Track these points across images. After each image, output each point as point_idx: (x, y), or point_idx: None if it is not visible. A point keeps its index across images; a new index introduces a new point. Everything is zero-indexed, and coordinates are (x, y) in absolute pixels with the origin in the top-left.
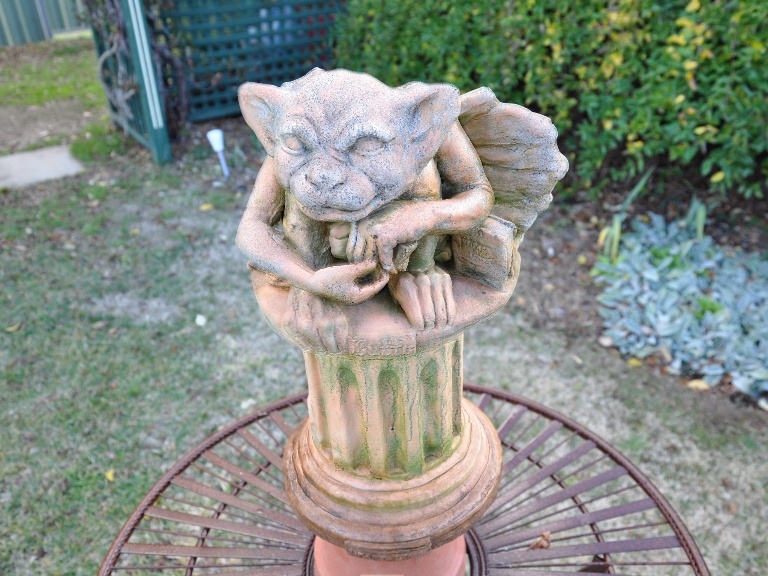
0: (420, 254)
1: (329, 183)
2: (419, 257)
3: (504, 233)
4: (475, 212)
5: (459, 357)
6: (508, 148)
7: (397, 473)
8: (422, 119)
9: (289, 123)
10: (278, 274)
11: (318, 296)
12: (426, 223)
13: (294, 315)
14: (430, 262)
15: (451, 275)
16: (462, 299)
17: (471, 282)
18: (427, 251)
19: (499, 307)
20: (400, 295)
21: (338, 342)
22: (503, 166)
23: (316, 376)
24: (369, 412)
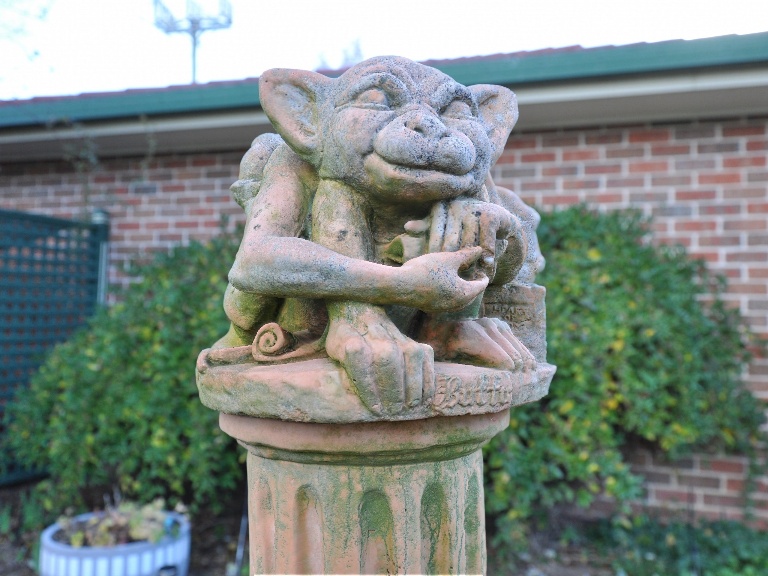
0: None
1: (438, 128)
2: None
3: None
4: None
5: None
6: None
7: None
8: (484, 119)
9: (374, 74)
10: (347, 272)
11: (406, 299)
12: None
13: (364, 339)
14: None
15: None
16: None
17: None
18: None
19: None
20: (466, 337)
21: (426, 379)
22: None
23: (302, 541)
24: (408, 568)
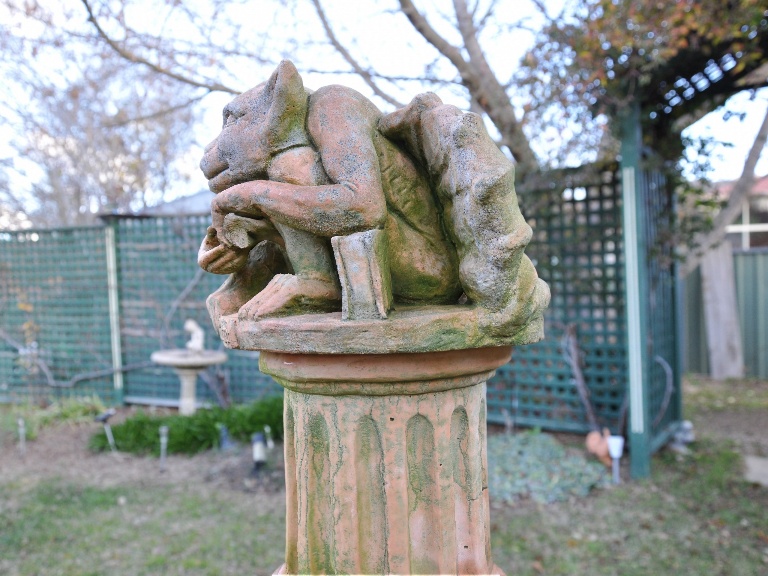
0: None
1: None
2: None
3: None
4: (302, 197)
5: (383, 452)
6: None
7: (296, 575)
8: None
9: None
10: None
11: None
12: (241, 191)
13: None
14: (306, 269)
15: None
16: (306, 314)
17: None
18: (289, 247)
19: (314, 327)
20: None
21: None
22: None
23: None
24: None
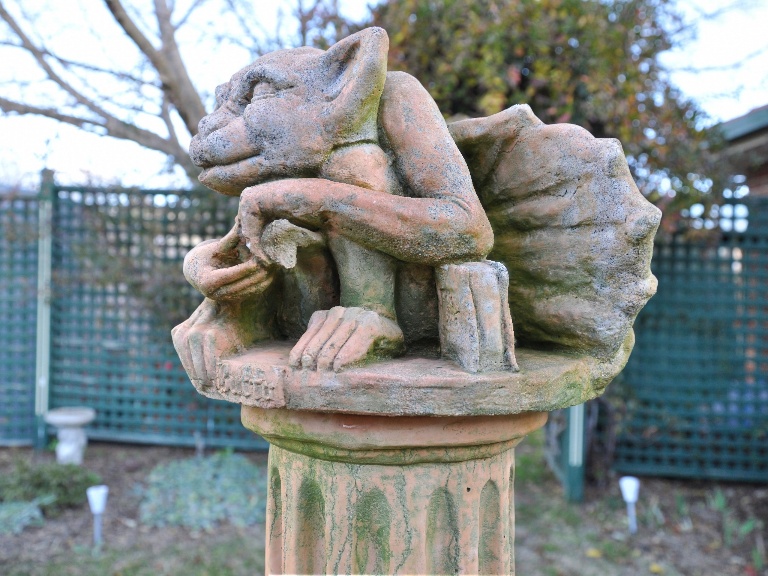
0: (344, 275)
1: (206, 127)
2: (345, 282)
3: (475, 269)
4: (407, 210)
5: (457, 531)
6: (557, 194)
7: None
8: (343, 78)
9: None
10: None
11: None
12: (306, 190)
13: None
14: (370, 301)
15: (434, 359)
16: None
17: (443, 361)
18: (352, 271)
19: (440, 382)
20: None
21: None
22: (554, 225)
23: None
24: (287, 553)
